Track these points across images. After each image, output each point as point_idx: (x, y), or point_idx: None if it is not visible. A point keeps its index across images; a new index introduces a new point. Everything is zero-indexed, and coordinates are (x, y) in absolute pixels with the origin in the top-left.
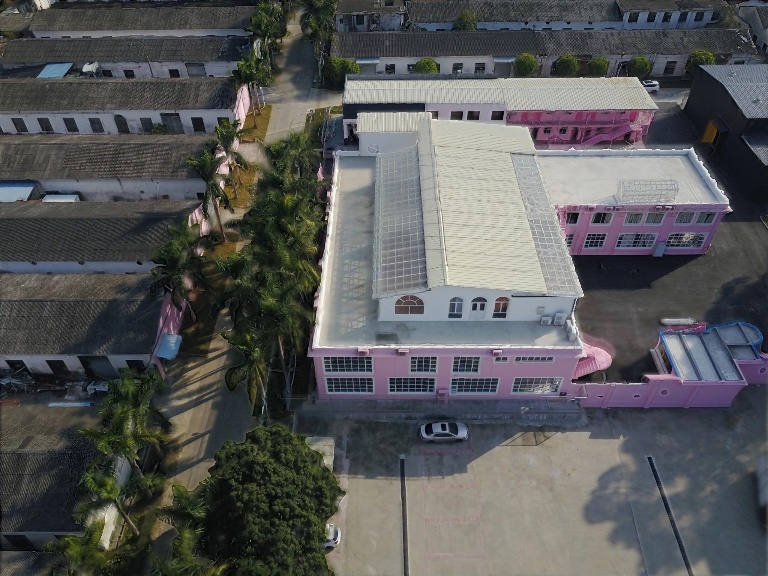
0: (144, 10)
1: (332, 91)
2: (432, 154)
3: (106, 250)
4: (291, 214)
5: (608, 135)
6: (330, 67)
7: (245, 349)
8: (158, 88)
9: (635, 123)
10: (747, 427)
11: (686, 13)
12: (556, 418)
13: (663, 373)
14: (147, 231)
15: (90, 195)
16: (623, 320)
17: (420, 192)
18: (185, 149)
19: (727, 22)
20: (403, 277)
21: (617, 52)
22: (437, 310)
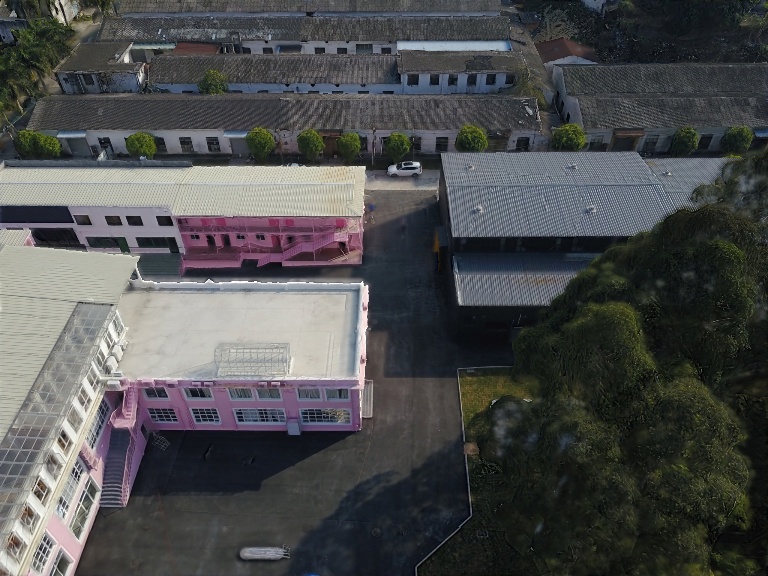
0: None
1: None
2: None
3: None
4: None
5: (309, 245)
6: (18, 143)
7: None
8: None
9: (343, 230)
10: None
11: (474, 75)
12: None
13: None
14: None
15: None
16: (191, 548)
17: None
18: None
19: (519, 88)
20: None
21: (373, 126)
22: None
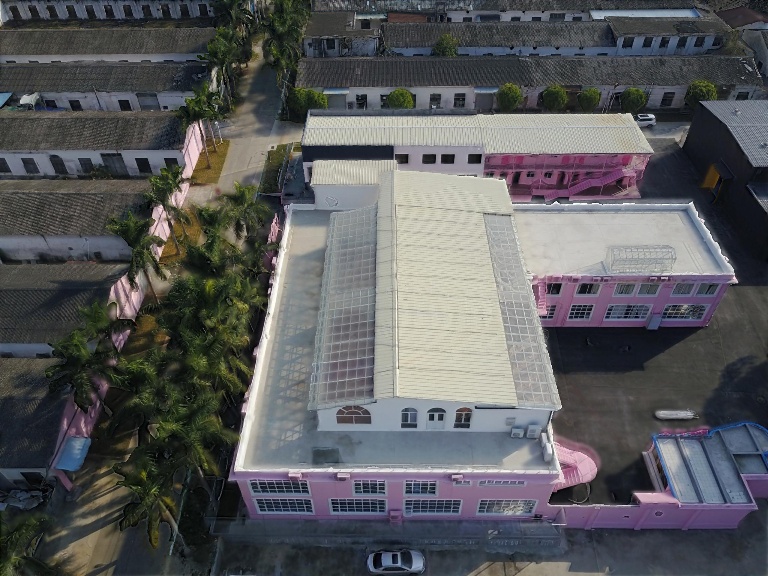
0: (96, 32)
1: (297, 124)
2: (392, 216)
3: (12, 329)
4: (214, 303)
5: (598, 180)
6: (294, 98)
7: (139, 490)
8: (99, 125)
9: (628, 167)
10: (757, 557)
11: (685, 38)
12: (530, 544)
13: (657, 485)
14: (61, 306)
15: (12, 252)
16: (611, 412)
17: (375, 266)
18: (119, 200)
19: (730, 48)
20: (346, 381)
21: (610, 82)
22: (387, 419)
